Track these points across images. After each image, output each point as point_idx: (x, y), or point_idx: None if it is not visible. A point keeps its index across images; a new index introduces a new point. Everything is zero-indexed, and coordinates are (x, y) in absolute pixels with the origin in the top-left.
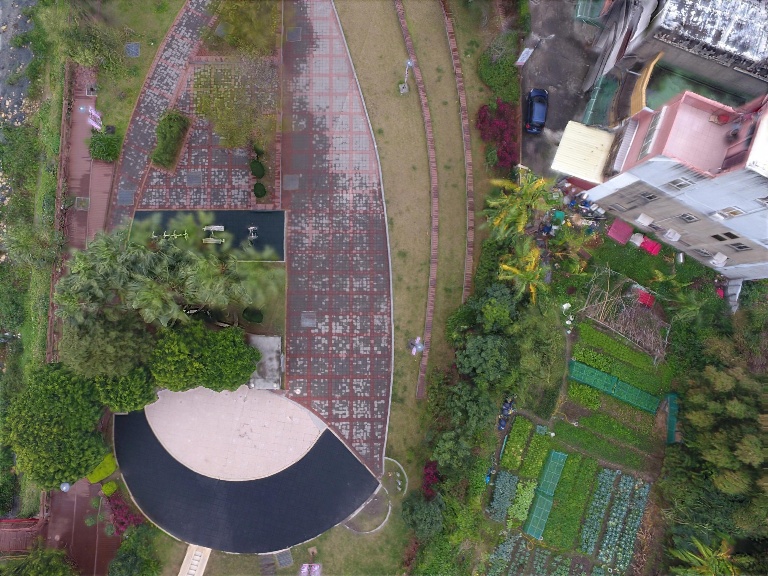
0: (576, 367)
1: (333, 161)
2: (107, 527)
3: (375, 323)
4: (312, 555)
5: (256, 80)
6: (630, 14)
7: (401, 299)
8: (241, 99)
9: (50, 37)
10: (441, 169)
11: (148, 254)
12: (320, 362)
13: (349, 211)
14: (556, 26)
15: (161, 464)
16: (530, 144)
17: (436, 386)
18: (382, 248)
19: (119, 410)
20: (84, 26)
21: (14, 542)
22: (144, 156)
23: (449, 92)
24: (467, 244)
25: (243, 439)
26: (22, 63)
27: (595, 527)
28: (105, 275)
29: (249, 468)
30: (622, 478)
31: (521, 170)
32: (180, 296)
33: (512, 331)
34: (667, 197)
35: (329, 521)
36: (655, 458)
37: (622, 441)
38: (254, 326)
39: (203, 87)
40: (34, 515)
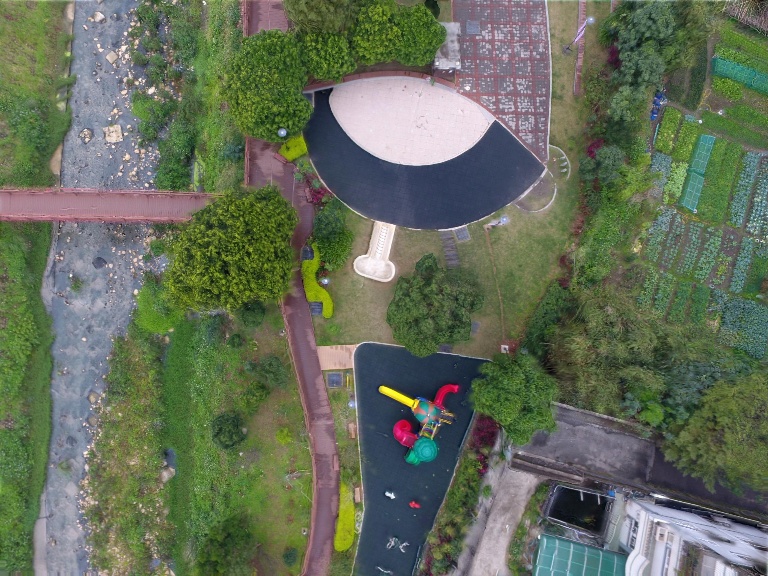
0: (718, 63)
1: None
2: (314, 180)
3: (533, 31)
4: (488, 230)
5: None
6: None
7: (555, 11)
8: None
9: None
10: None
11: None
12: (486, 64)
13: None
14: None
15: (347, 150)
16: None
17: (596, 75)
18: None
19: (327, 69)
20: None
21: None
22: None
23: None
24: None
25: (420, 129)
26: None
27: (742, 203)
28: None
29: (426, 155)
30: (763, 161)
31: None
32: None
33: (672, 6)
34: None
35: (501, 200)
36: None
37: (761, 129)
38: None
39: None
40: None
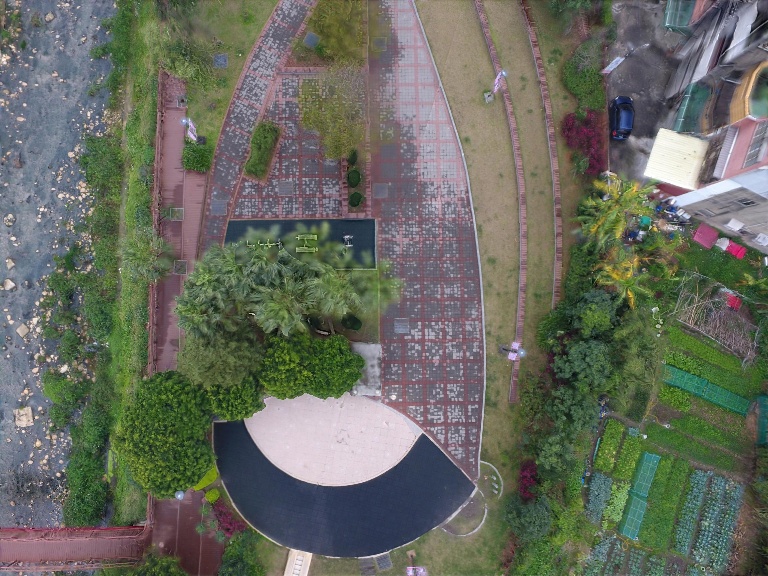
0: (667, 370)
1: (421, 169)
2: (217, 534)
3: (467, 329)
4: (411, 558)
5: (343, 90)
6: (722, 23)
7: (492, 305)
8: (329, 109)
9: (131, 48)
10: (528, 176)
11: (270, 265)
12: (414, 368)
13: (438, 219)
14: (637, 34)
15: (261, 470)
16: (615, 151)
17: (531, 390)
18: (472, 255)
19: (230, 418)
20: (176, 38)
21: (120, 549)
22: (235, 166)
23: (534, 100)
24: (556, 250)
25: (341, 445)
26: (102, 74)
27: (688, 527)
28: (229, 287)
29: (347, 473)
30: (713, 478)
31: (610, 177)
32: (298, 306)
33: (612, 336)
34: (767, 203)
35: (427, 524)
36: (745, 458)
37: (712, 442)
38: (349, 333)
39: (291, 97)
40: (137, 522)
